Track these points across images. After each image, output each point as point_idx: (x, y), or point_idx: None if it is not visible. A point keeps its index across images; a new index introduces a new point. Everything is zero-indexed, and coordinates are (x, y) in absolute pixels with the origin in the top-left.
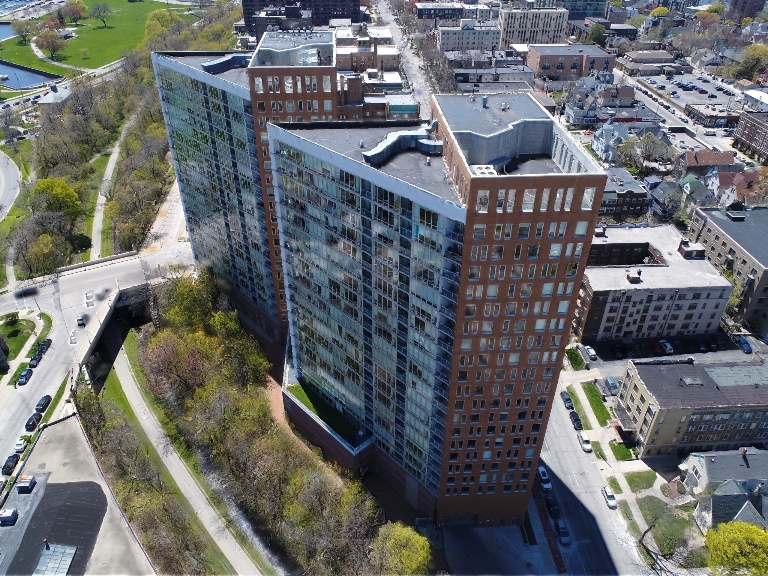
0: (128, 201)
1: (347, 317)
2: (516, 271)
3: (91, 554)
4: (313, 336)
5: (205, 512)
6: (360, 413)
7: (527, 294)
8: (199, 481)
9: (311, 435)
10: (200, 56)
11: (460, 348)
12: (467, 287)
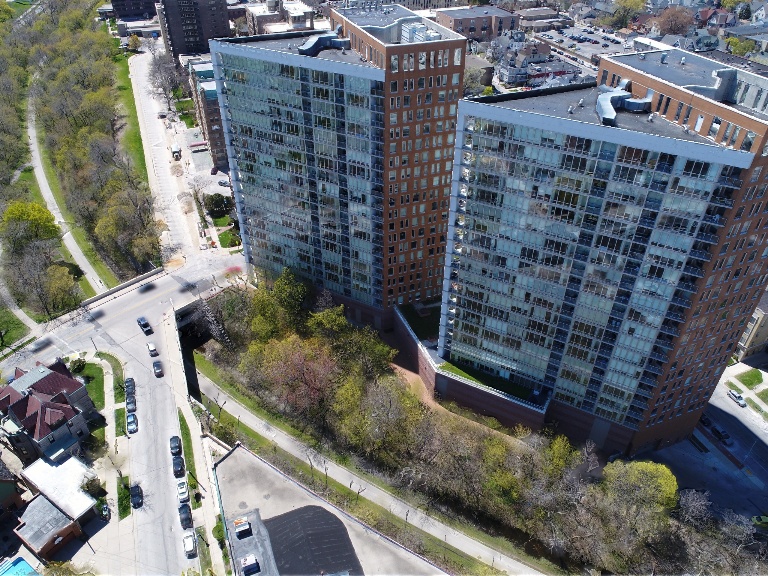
0: (125, 215)
1: (543, 282)
2: (766, 205)
3: (363, 573)
4: (480, 310)
5: (398, 508)
6: (538, 373)
7: (766, 225)
8: (372, 481)
9: (475, 408)
10: (264, 41)
11: (705, 285)
12: (730, 227)
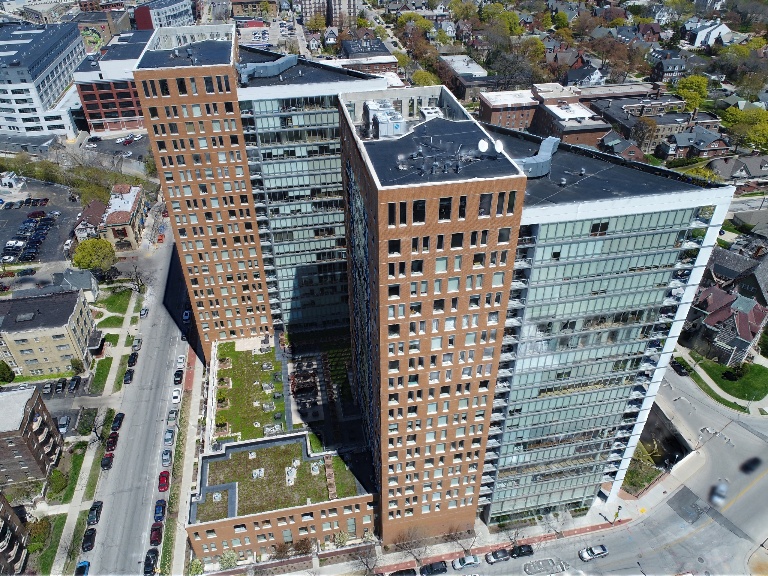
0: None
1: None
2: None
3: None
4: None
5: None
6: None
7: None
8: None
9: None
10: None
11: None
12: None
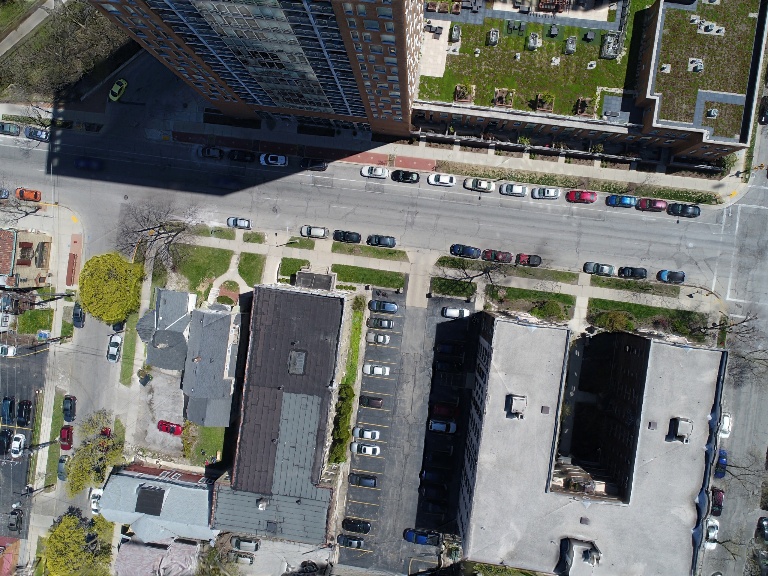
0: None
1: None
2: None
3: None
4: None
5: None
6: None
7: None
8: None
9: None
10: None
11: None
12: None
